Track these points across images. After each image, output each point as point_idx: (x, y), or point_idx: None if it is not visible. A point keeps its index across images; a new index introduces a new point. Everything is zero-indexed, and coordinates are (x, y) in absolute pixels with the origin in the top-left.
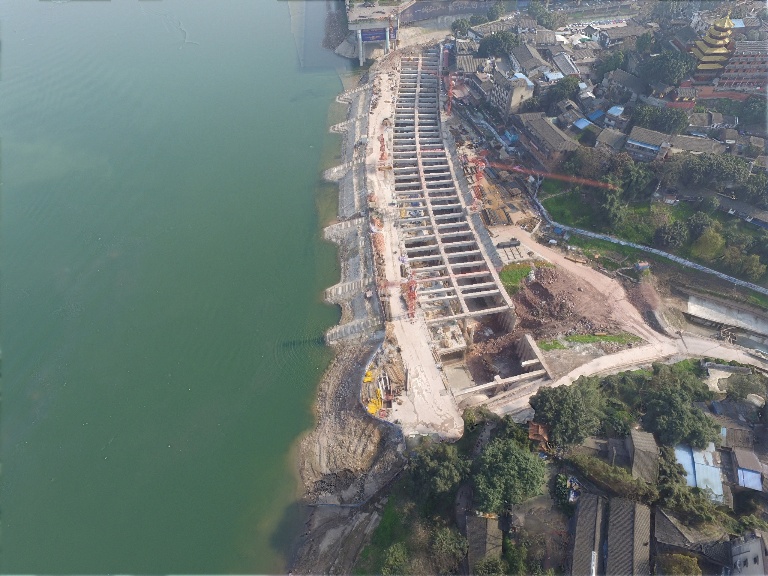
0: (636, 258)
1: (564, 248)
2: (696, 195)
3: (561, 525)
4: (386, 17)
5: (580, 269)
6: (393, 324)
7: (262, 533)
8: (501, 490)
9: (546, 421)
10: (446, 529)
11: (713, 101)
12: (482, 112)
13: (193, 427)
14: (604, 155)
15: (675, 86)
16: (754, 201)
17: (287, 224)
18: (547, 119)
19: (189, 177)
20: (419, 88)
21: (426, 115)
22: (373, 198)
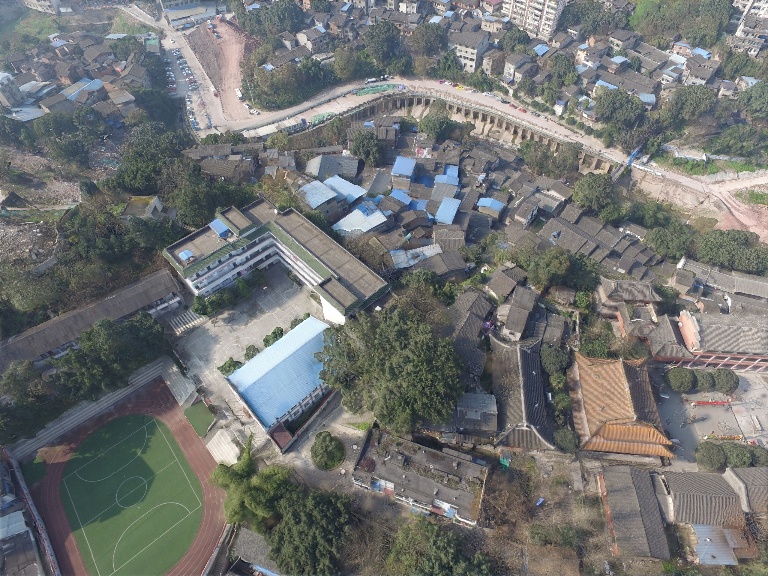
0: None
1: None
2: None
3: None
4: None
5: None
6: None
7: None
8: None
9: None
10: None
11: None
12: None
13: None
14: None
15: None
16: None
17: None
18: None
19: None
20: None
21: None
22: None
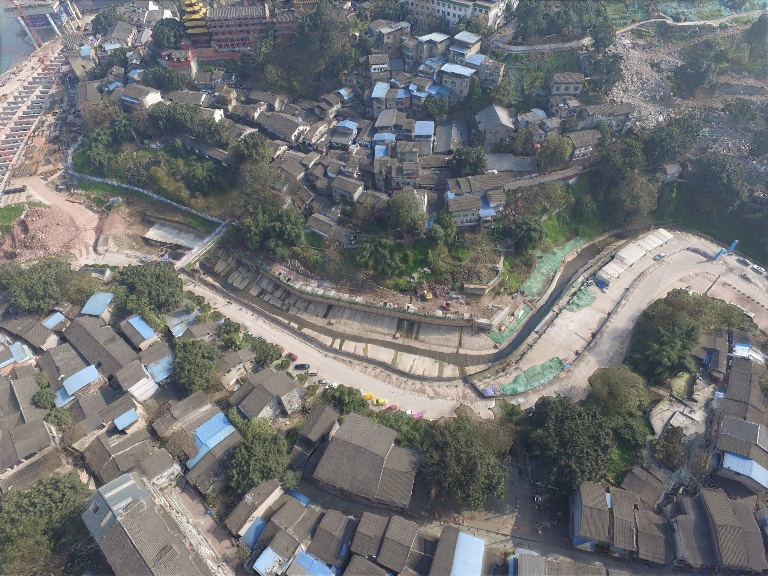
0: (116, 195)
1: (71, 192)
2: None
3: None
4: (41, 4)
5: (73, 208)
6: None
7: None
8: None
9: None
10: None
11: (219, 61)
12: None
13: None
14: (94, 109)
15: (174, 49)
16: None
17: None
18: (92, 84)
19: None
20: None
21: (47, 90)
22: None
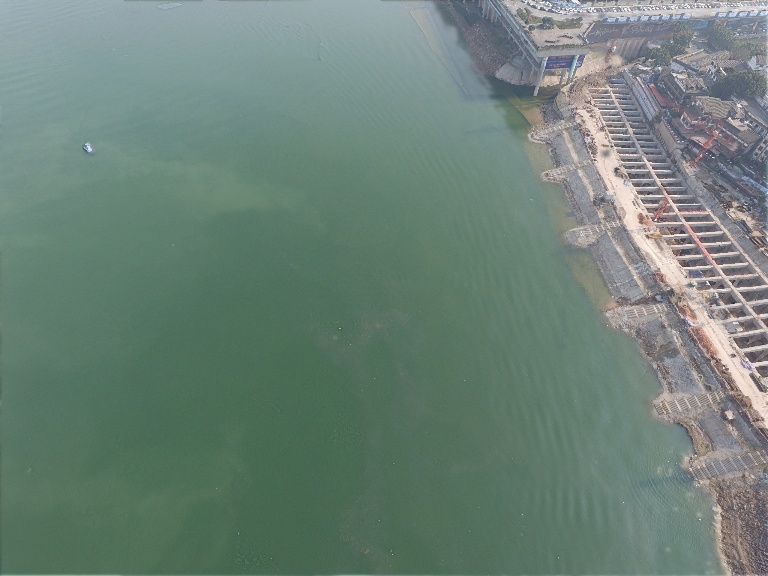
0: None
1: None
2: None
3: None
4: None
5: None
6: None
7: None
8: None
9: None
10: None
11: None
12: (740, 166)
13: None
14: None
15: None
16: None
17: None
18: None
19: (406, 239)
20: (631, 129)
21: (658, 164)
22: (664, 277)
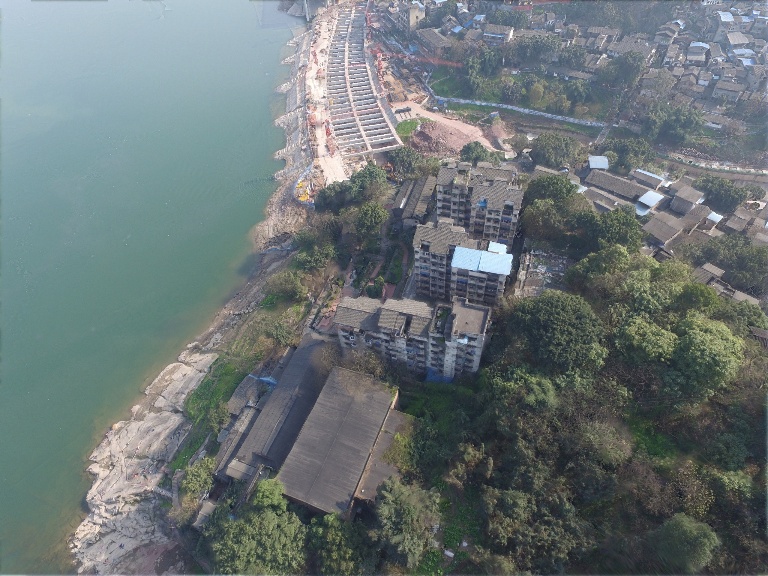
0: (491, 111)
1: (444, 112)
2: (532, 66)
3: (390, 193)
4: None
5: (453, 123)
6: (319, 159)
7: (231, 268)
8: (359, 184)
9: (392, 160)
10: (331, 213)
11: (549, 6)
12: (394, 36)
13: (184, 226)
14: (466, 43)
15: None
16: (568, 64)
17: (248, 120)
18: (434, 29)
19: (173, 99)
20: (350, 29)
21: (354, 45)
22: None
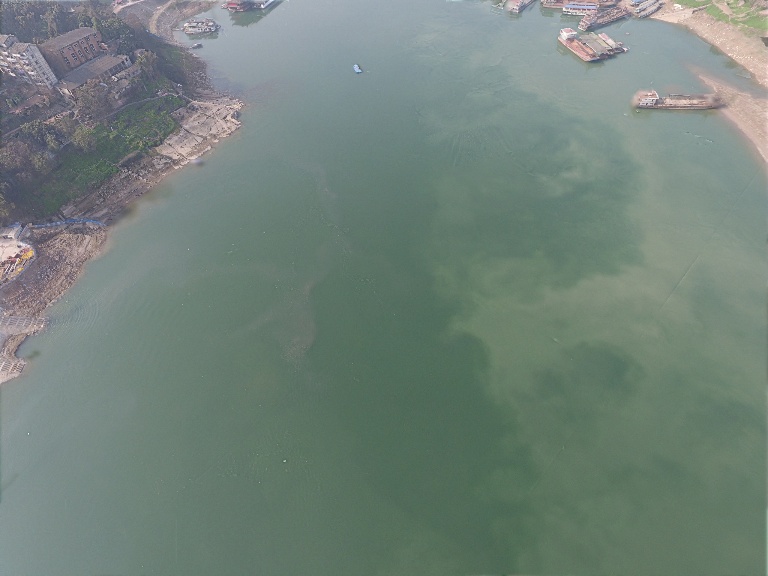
0: None
1: None
2: None
3: None
4: None
5: None
6: None
7: (138, 216)
8: None
9: None
10: (4, 160)
11: None
12: None
13: (172, 260)
14: None
15: None
16: None
17: None
18: None
19: None
20: None
21: None
22: None
